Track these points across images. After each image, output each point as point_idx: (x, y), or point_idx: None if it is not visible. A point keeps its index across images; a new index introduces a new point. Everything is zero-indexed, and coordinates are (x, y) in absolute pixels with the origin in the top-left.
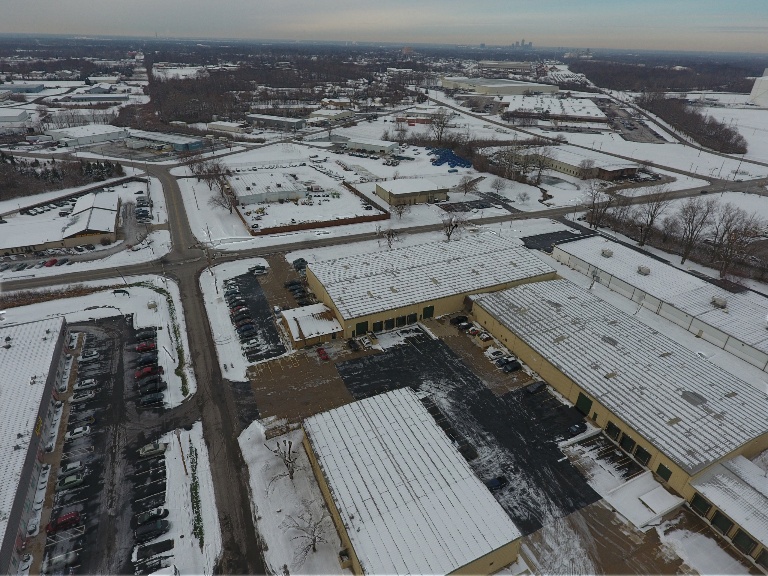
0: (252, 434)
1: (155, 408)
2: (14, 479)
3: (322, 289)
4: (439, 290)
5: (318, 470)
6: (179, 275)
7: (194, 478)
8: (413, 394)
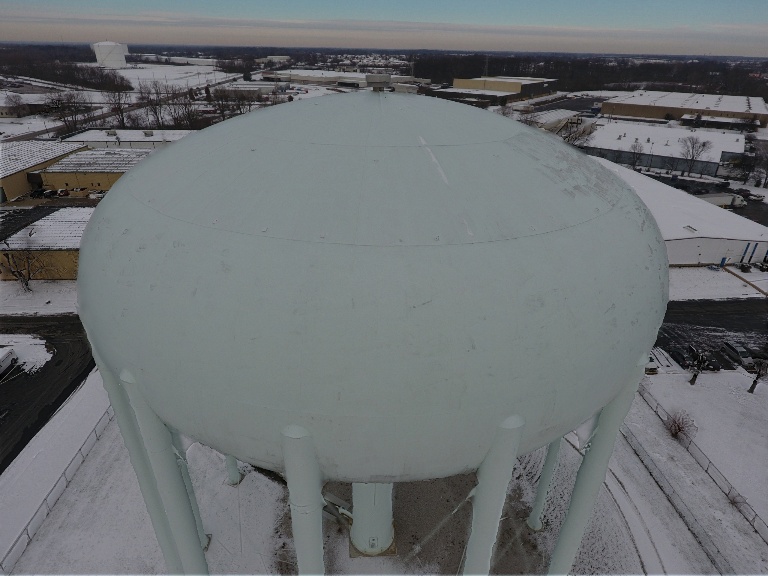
0: None
1: None
2: None
3: None
4: None
5: (55, 261)
6: None
7: None
8: (74, 208)
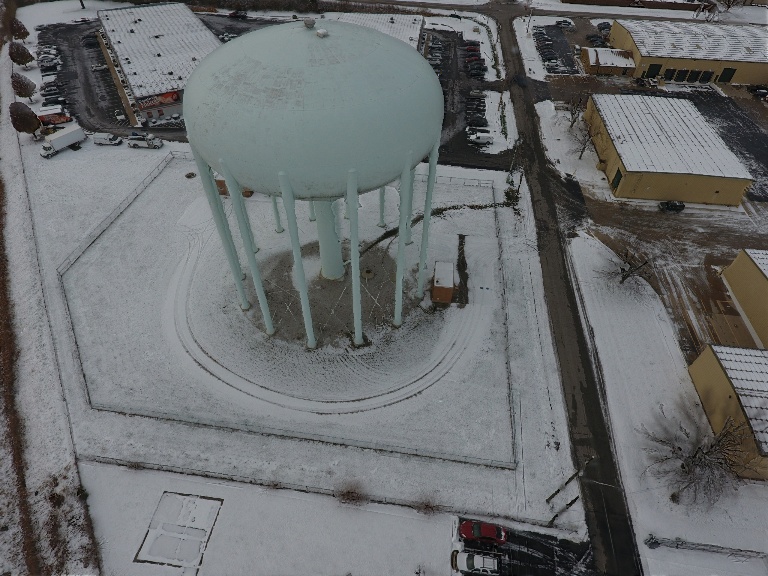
0: (545, 106)
1: (479, 78)
2: None
3: (626, 35)
4: (750, 56)
5: (596, 122)
6: (497, 17)
7: (503, 113)
8: (691, 104)
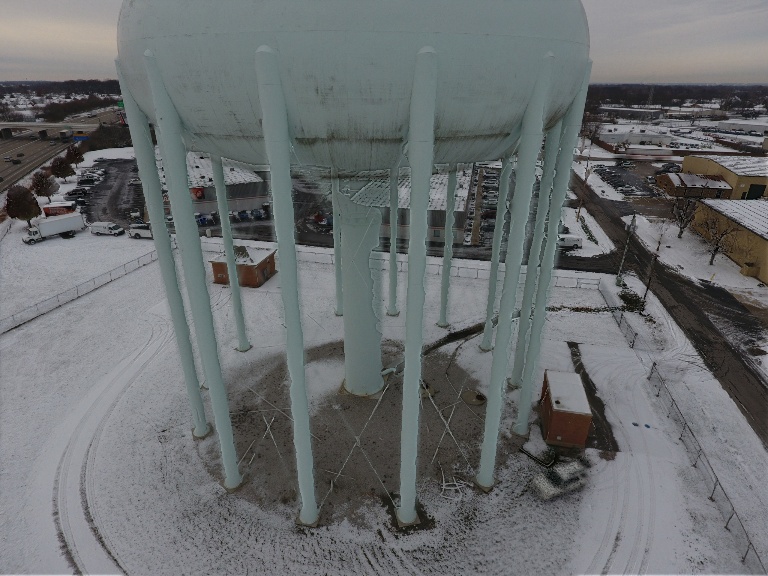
0: None
1: None
2: (467, 182)
3: (708, 163)
4: None
5: None
6: None
7: (584, 224)
8: None
